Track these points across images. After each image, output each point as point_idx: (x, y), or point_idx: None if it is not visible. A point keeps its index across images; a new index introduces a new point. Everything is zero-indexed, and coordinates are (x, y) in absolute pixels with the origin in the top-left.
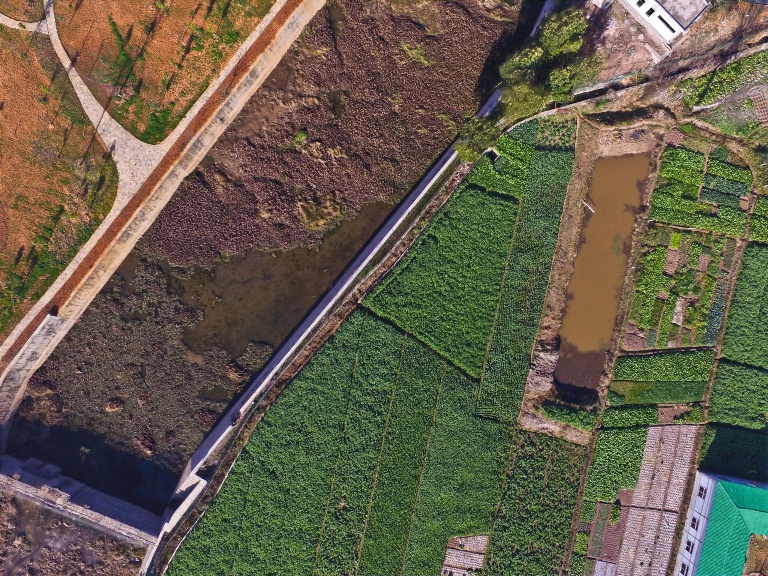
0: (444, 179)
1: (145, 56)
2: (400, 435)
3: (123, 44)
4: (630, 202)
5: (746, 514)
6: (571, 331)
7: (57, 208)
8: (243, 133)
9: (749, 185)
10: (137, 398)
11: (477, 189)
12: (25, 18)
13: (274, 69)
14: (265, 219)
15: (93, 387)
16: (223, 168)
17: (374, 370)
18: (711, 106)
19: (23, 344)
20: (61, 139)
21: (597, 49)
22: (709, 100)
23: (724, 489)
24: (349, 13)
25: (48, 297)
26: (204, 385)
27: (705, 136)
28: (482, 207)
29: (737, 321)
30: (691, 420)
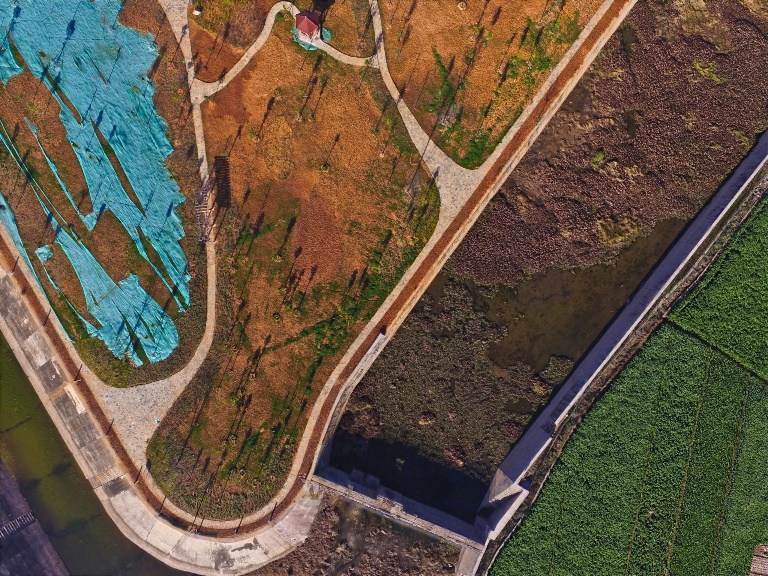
0: (745, 194)
1: (465, 85)
2: (708, 445)
3: (446, 75)
4: None
5: None
6: None
7: (386, 233)
8: (542, 155)
9: None
10: (447, 412)
11: None
12: (358, 54)
13: (571, 92)
14: (566, 238)
15: (407, 401)
16: (524, 189)
17: (682, 382)
18: None
19: (357, 362)
20: (390, 167)
21: None
22: None
23: None
24: (643, 35)
25: (378, 317)
26: (509, 398)
27: None
28: None
29: None
30: None
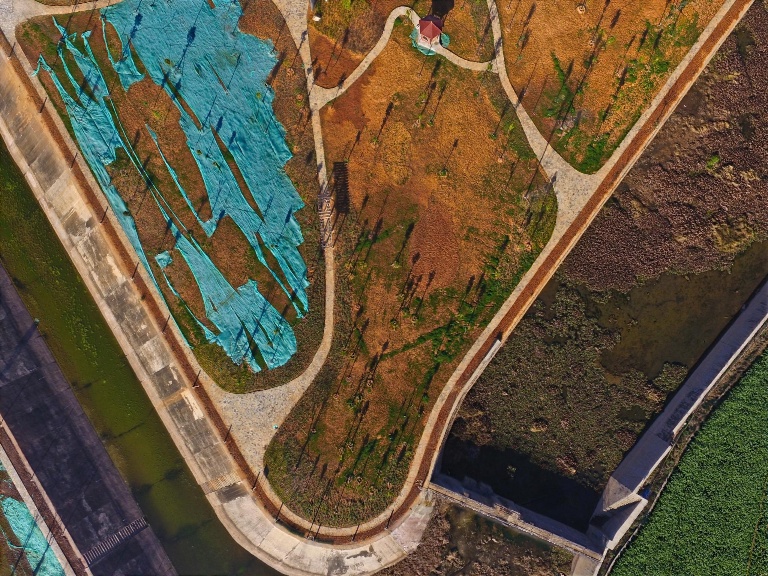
0: None
1: (584, 89)
2: None
3: (564, 79)
4: None
5: None
6: None
7: (503, 238)
8: (656, 159)
9: None
10: (559, 419)
11: None
12: (477, 58)
13: (685, 95)
14: (680, 243)
15: (518, 408)
16: (638, 194)
17: None
18: None
19: (474, 369)
20: (508, 172)
21: None
22: None
23: None
24: (758, 37)
25: (495, 324)
26: (622, 406)
27: None
28: None
29: None
30: None
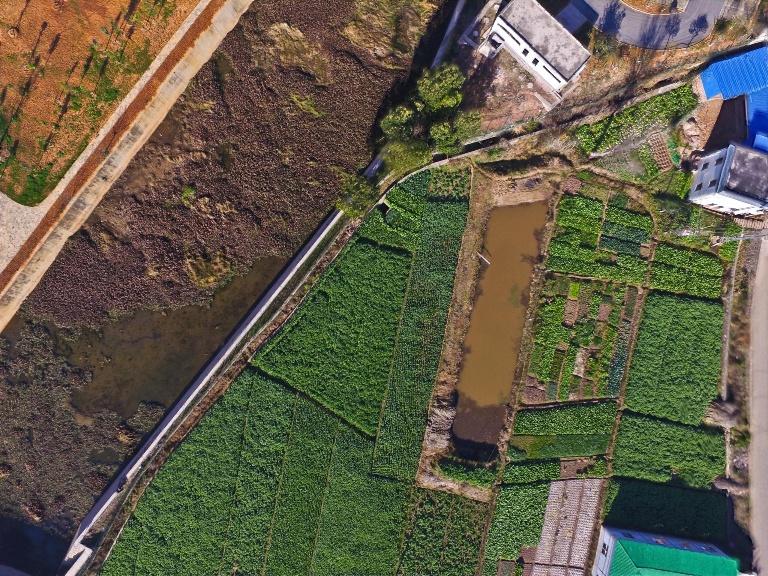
0: (334, 233)
1: (20, 117)
2: (293, 497)
3: None
4: (528, 252)
5: (646, 573)
6: (469, 385)
7: None
8: (129, 190)
9: (649, 232)
10: (25, 463)
11: (368, 243)
12: None
13: (160, 124)
14: (153, 277)
15: None
16: (109, 226)
17: (265, 431)
18: (604, 154)
19: None
20: None
21: (487, 98)
22: (606, 146)
23: (623, 548)
24: (236, 65)
25: None
26: (94, 448)
27: (603, 183)
28: (373, 261)
29: (639, 372)
30: (594, 474)
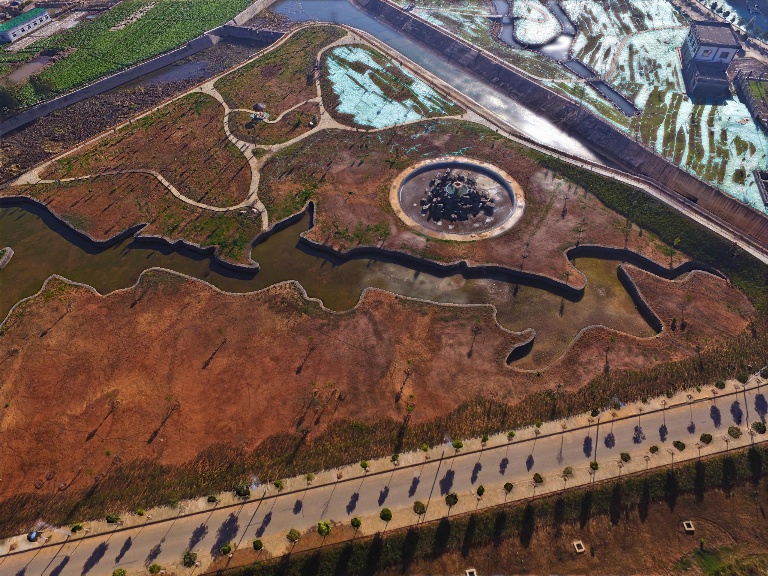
0: None
1: None
2: None
3: None
4: None
5: (0, 25)
6: None
7: None
8: None
9: None
10: None
11: (55, 91)
12: None
13: None
14: None
15: None
16: None
17: None
18: None
19: None
20: None
21: None
22: None
23: (4, 29)
24: None
25: None
26: None
27: None
28: None
29: None
30: (5, 50)
